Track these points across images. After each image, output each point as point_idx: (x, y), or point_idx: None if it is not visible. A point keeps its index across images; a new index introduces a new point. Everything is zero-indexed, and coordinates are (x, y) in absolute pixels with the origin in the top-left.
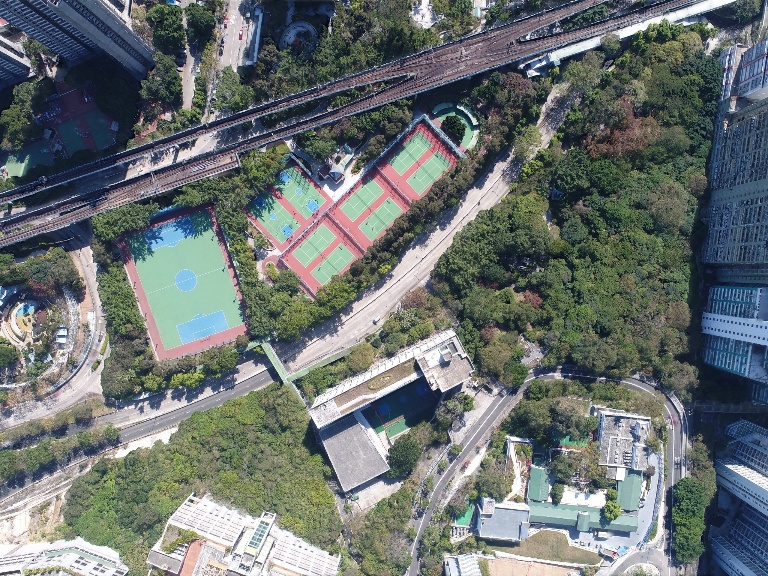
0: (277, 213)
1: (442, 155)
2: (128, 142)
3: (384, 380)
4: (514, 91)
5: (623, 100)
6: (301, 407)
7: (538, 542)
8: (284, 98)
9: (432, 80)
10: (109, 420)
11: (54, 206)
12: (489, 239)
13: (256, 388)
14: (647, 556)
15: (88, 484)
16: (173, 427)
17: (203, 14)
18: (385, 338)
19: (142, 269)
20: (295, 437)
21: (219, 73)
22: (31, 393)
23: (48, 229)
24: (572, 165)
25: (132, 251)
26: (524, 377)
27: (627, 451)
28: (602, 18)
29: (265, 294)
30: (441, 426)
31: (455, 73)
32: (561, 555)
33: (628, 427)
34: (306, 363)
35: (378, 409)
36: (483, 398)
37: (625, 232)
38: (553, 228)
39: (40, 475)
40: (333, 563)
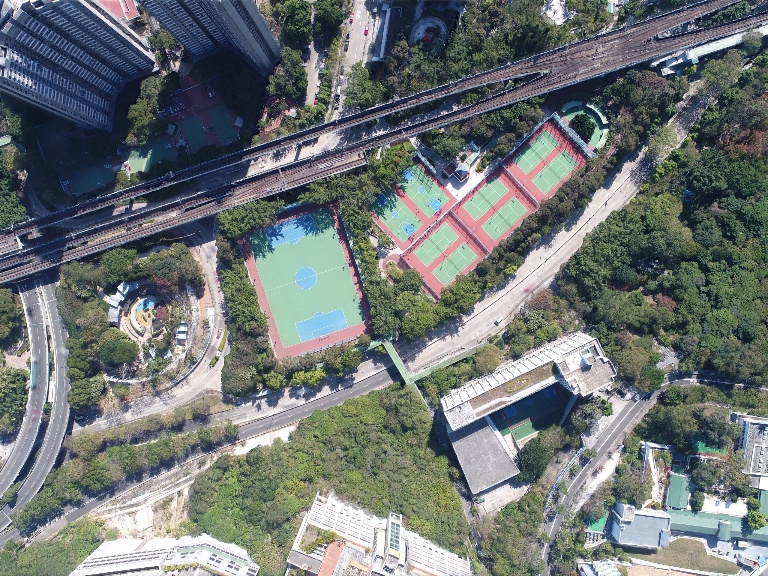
0: (399, 211)
1: (569, 154)
2: (253, 138)
3: (521, 383)
4: (649, 89)
5: (763, 100)
6: (424, 408)
7: (676, 550)
8: (415, 95)
9: (566, 78)
10: (226, 417)
11: (180, 202)
12: (622, 241)
13: (375, 387)
14: None
15: (211, 481)
16: (291, 425)
17: (334, 9)
18: (510, 339)
19: (262, 266)
20: (419, 438)
21: (344, 69)
22: (151, 388)
23: (173, 225)
24: (710, 166)
25: (252, 248)
26: (661, 382)
27: None
28: (743, 15)
29: (390, 293)
30: (575, 430)
31: (589, 71)
32: (700, 564)
33: None
34: (426, 363)
35: (504, 411)
36: (615, 402)
37: (766, 235)
38: (685, 230)
39: (158, 470)
40: (465, 566)
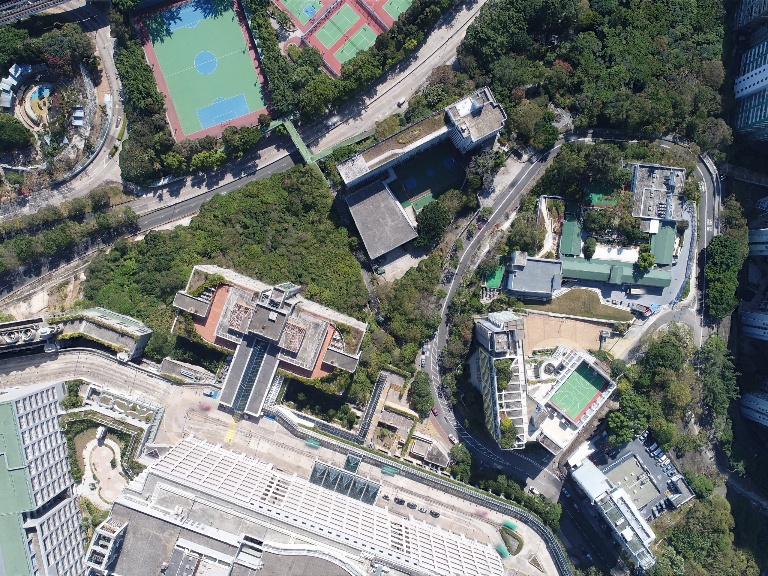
0: None
1: None
2: None
3: (413, 134)
4: None
5: None
6: (325, 186)
7: (570, 299)
8: None
9: None
10: None
11: None
12: (518, 6)
13: None
14: (679, 316)
15: (108, 261)
16: (193, 214)
17: None
18: (411, 116)
19: (160, 51)
20: (319, 214)
21: None
22: (47, 176)
23: (64, 0)
24: None
25: (150, 32)
26: (555, 138)
27: (661, 202)
28: None
29: (288, 67)
30: (470, 188)
31: None
32: (593, 311)
33: (662, 178)
34: (329, 147)
35: (404, 183)
36: (512, 164)
37: None
38: (583, 1)
39: (57, 264)
40: (361, 323)
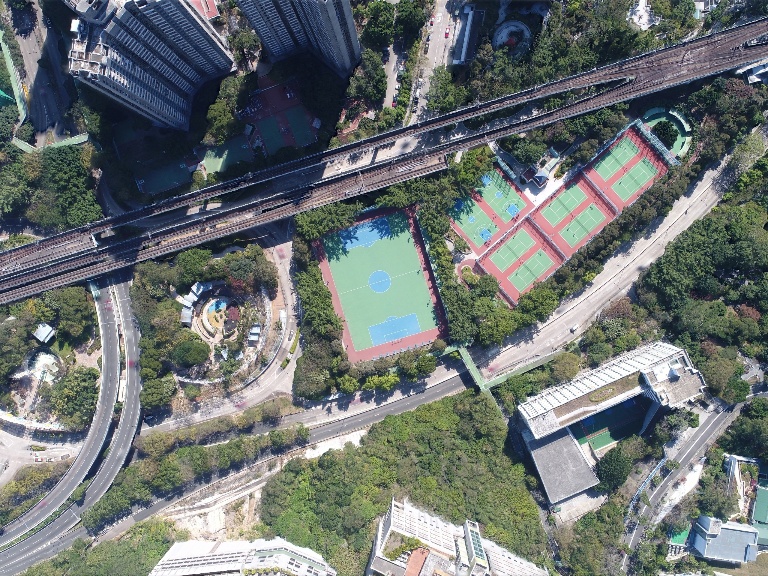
0: (476, 216)
1: (650, 161)
2: (331, 140)
3: (606, 392)
4: (735, 97)
5: None
6: (499, 415)
7: (761, 565)
8: (498, 99)
9: (651, 84)
10: (296, 419)
11: (257, 203)
12: (706, 250)
13: (447, 393)
14: None
15: (284, 484)
16: (361, 429)
17: (418, 11)
18: (587, 348)
19: (336, 269)
20: (494, 445)
21: (423, 72)
22: (223, 390)
23: (250, 226)
24: None
25: (326, 250)
26: (746, 394)
27: None
28: None
29: (468, 299)
30: (657, 441)
31: (676, 77)
32: None
33: None
34: (500, 370)
35: (582, 420)
36: None
37: None
38: None
39: (226, 472)
40: None
